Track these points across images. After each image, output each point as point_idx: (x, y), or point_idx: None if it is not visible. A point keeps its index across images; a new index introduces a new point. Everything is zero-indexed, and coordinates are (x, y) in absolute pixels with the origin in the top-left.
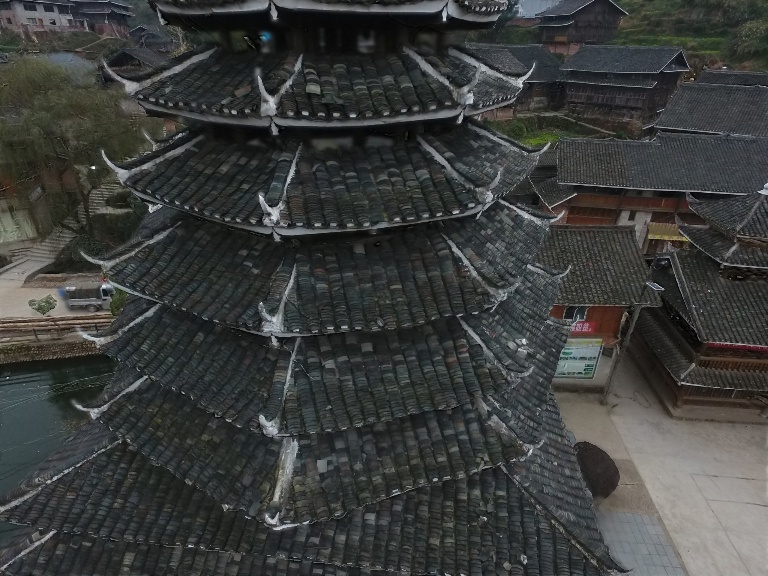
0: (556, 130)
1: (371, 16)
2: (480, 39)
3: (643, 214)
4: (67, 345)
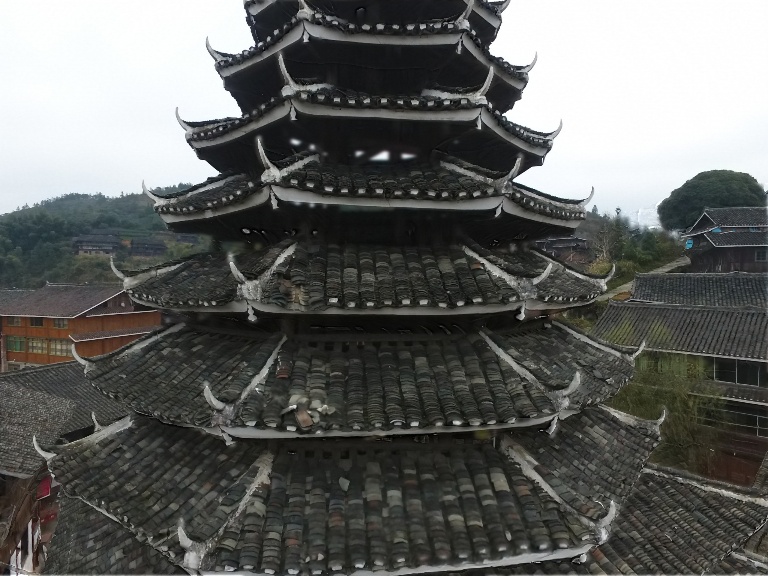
0: None
1: (264, 61)
2: None
3: None
4: None
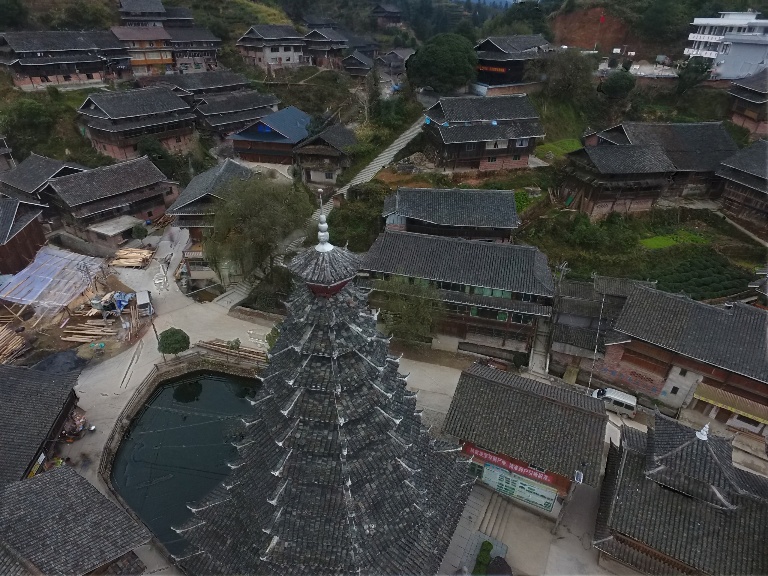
0: (701, 225)
1: None
2: (659, 100)
3: (694, 374)
4: (241, 369)
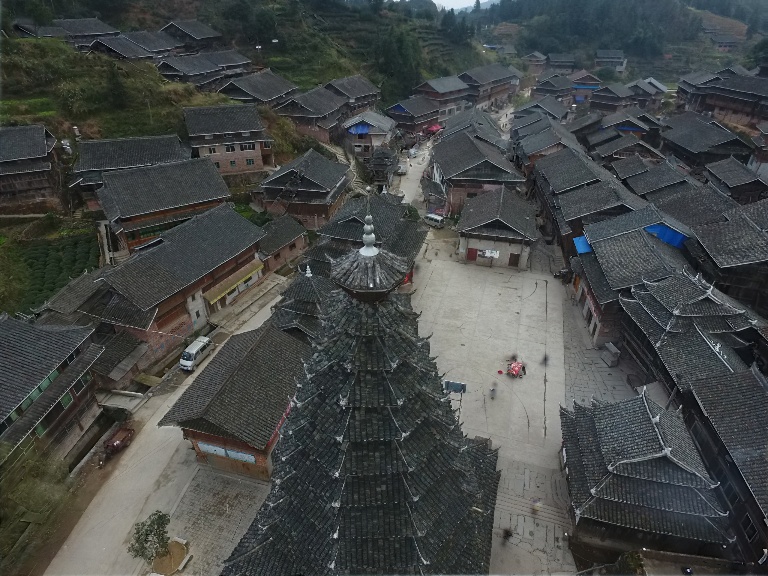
0: None
1: None
2: None
3: (198, 292)
4: None
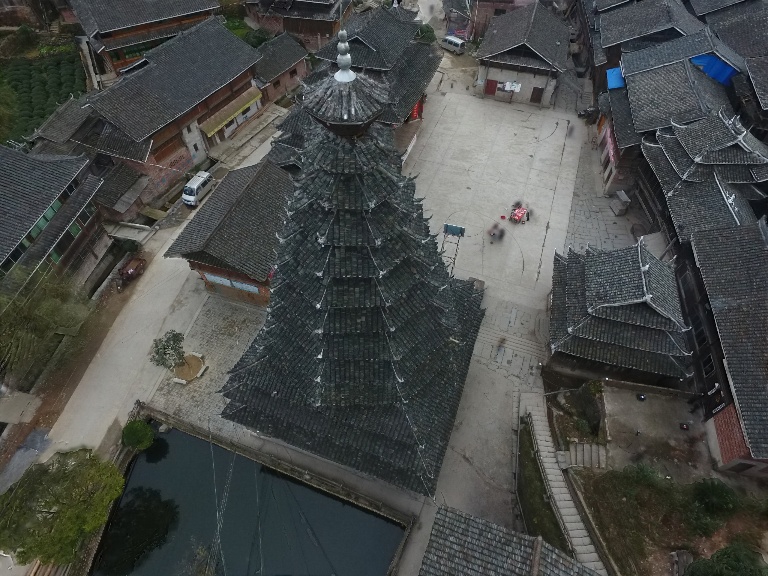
0: None
1: None
2: None
3: (193, 124)
4: None
